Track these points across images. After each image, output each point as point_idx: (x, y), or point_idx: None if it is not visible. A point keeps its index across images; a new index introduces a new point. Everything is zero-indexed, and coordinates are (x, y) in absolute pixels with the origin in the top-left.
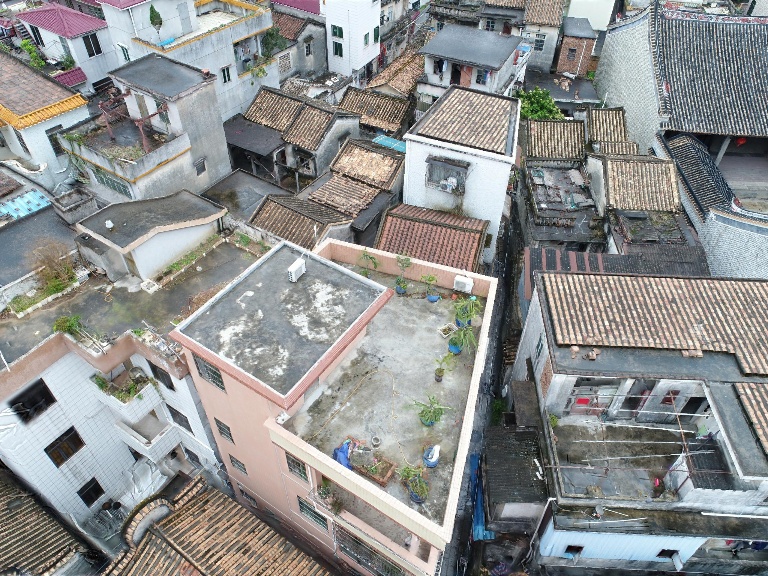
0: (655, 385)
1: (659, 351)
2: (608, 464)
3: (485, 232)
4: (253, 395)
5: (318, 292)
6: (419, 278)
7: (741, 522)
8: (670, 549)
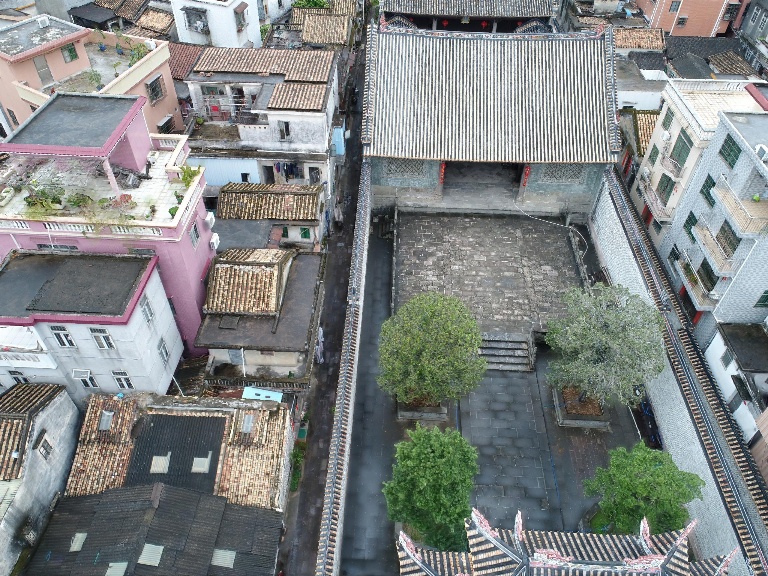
0: None
1: (247, 74)
2: (196, 114)
3: (207, 46)
4: (6, 68)
5: (51, 31)
6: (133, 47)
7: (276, 154)
8: (245, 173)
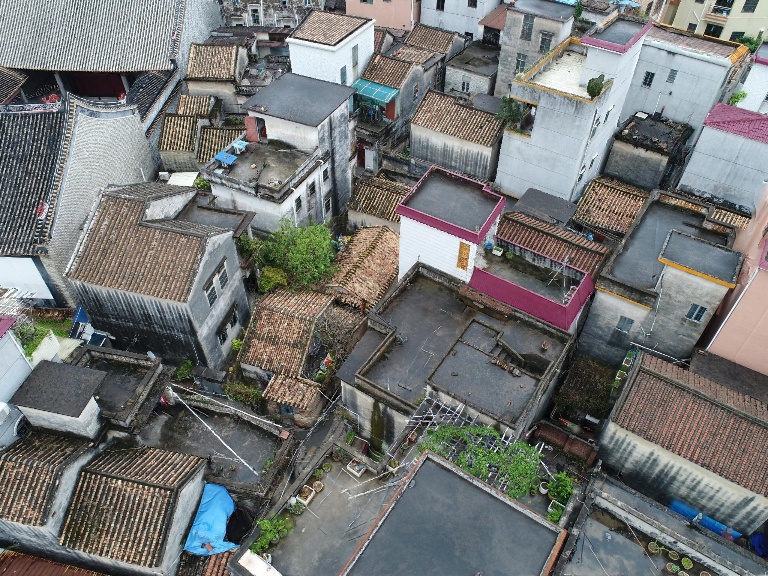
0: None
1: None
2: None
3: None
4: None
5: None
6: None
7: None
8: None
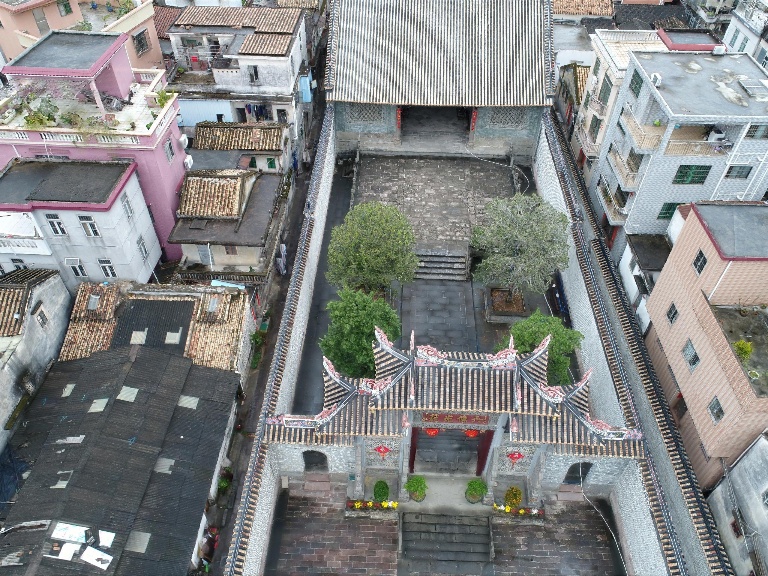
0: (219, 43)
1: (222, 27)
2: None
3: None
4: (8, 18)
5: None
6: None
7: (247, 96)
8: (220, 114)
